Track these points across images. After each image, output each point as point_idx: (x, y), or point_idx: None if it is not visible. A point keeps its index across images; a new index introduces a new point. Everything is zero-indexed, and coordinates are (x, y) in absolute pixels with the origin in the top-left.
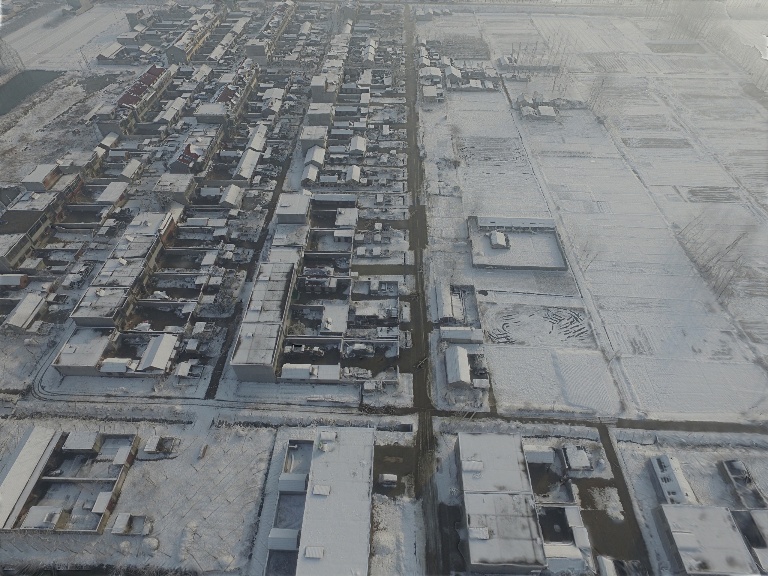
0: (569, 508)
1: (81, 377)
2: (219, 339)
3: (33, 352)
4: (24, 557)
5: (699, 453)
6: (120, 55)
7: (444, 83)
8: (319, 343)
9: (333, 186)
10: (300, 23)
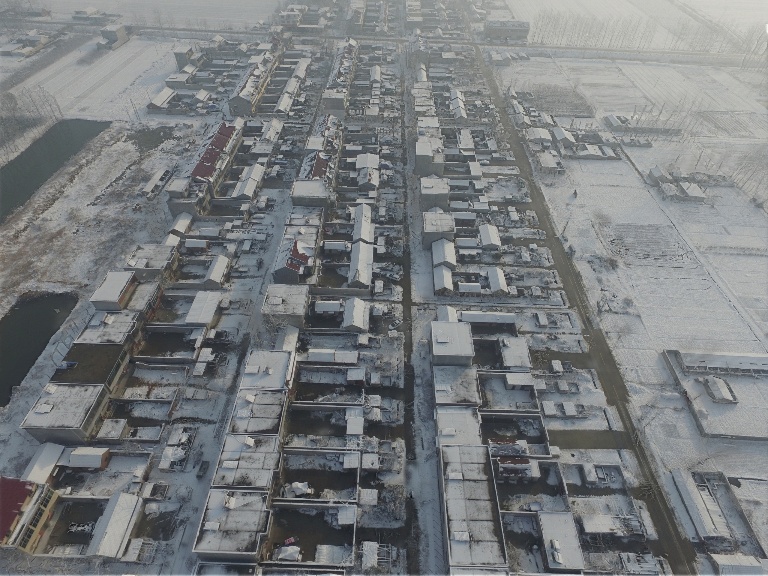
0: None
1: None
2: (399, 572)
3: None
4: None
5: None
6: (172, 102)
7: (556, 148)
8: None
9: (475, 296)
10: (366, 66)
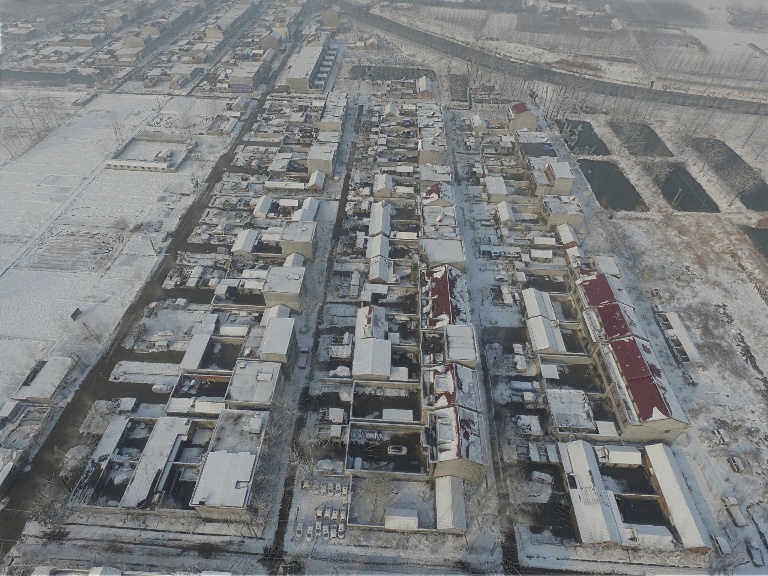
0: (222, 78)
1: None
2: None
3: None
4: (402, 68)
5: (156, 90)
6: None
7: None
8: None
9: None
10: None
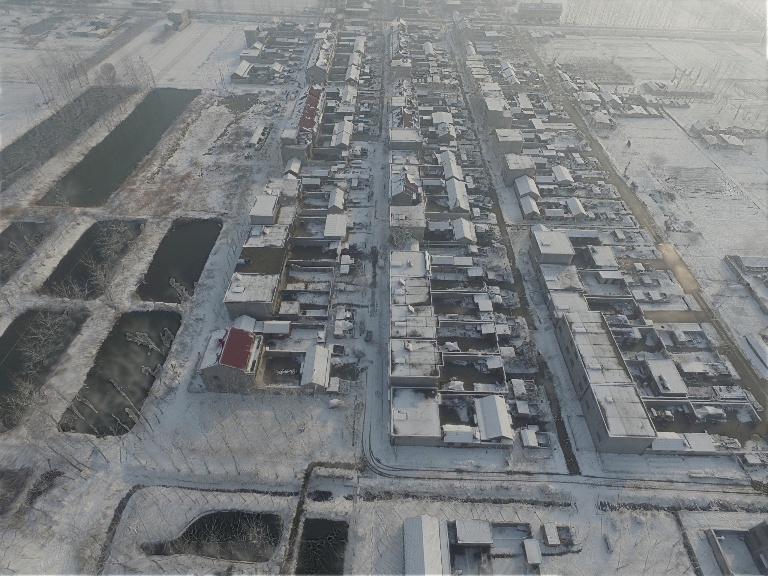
0: None
1: (415, 447)
2: (542, 399)
3: (342, 416)
4: None
5: None
6: (250, 74)
7: (605, 108)
8: (659, 405)
9: (558, 220)
10: (417, 43)
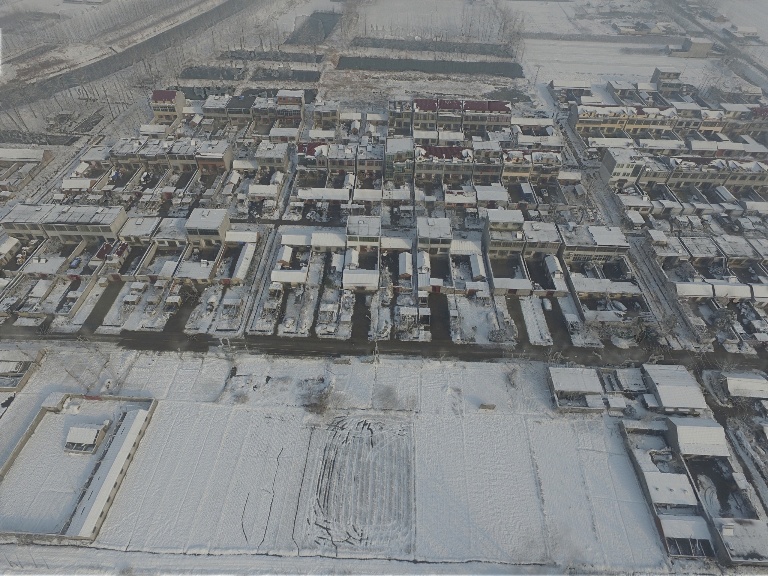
0: None
1: None
2: None
3: None
4: None
5: None
6: (572, 92)
7: None
8: None
9: None
10: None
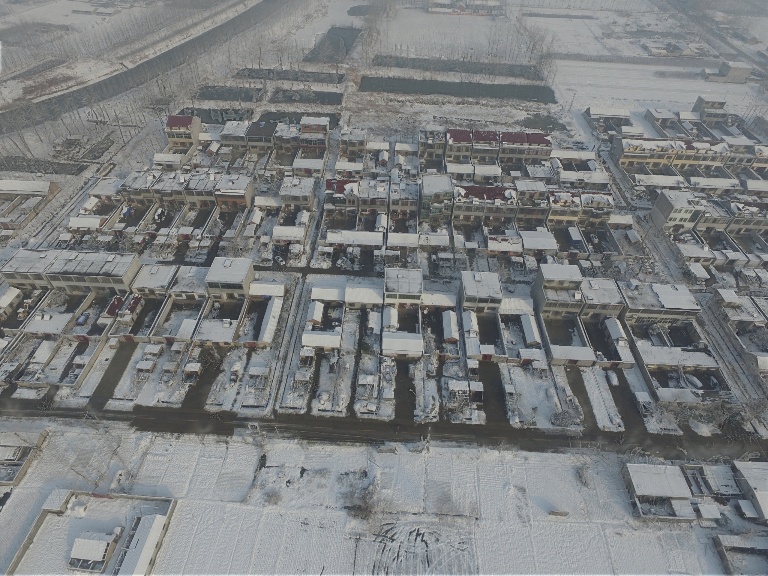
0: None
1: None
2: None
3: None
4: None
5: None
6: (610, 120)
7: None
8: None
9: None
10: None
